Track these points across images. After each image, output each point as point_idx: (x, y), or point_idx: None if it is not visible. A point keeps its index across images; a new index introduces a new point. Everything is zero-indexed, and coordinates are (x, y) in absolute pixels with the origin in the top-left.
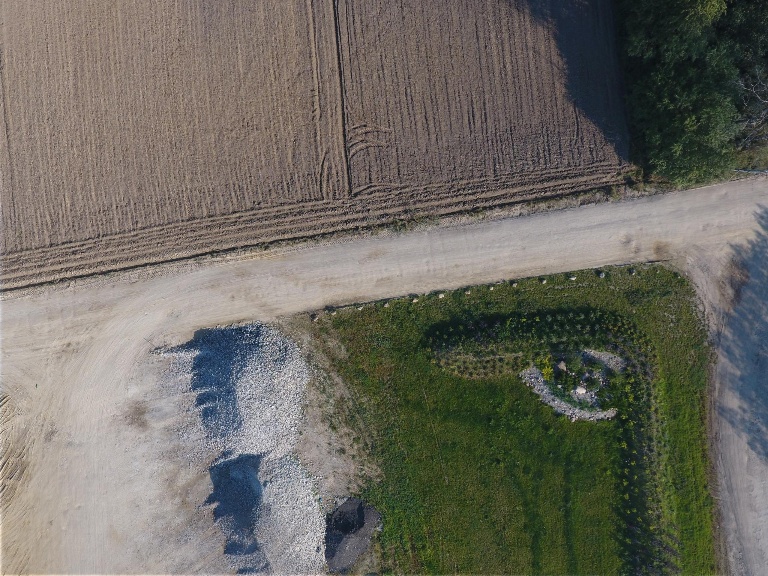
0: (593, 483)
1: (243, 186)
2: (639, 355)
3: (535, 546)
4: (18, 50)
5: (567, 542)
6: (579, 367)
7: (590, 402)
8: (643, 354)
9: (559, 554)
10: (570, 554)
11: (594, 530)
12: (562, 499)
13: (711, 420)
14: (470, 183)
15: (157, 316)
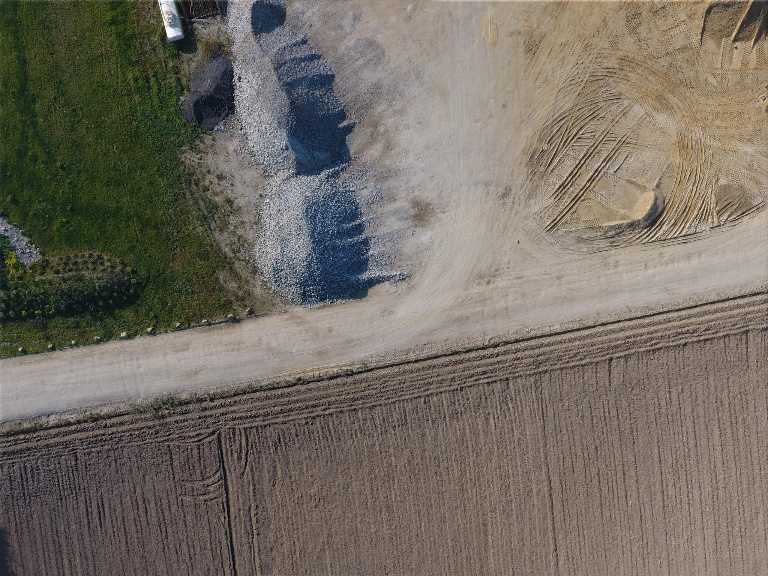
0: None
1: (323, 440)
2: None
3: (23, 81)
4: (540, 567)
5: None
6: None
7: None
8: None
9: None
10: None
11: None
12: None
13: None
14: (100, 446)
15: (404, 311)
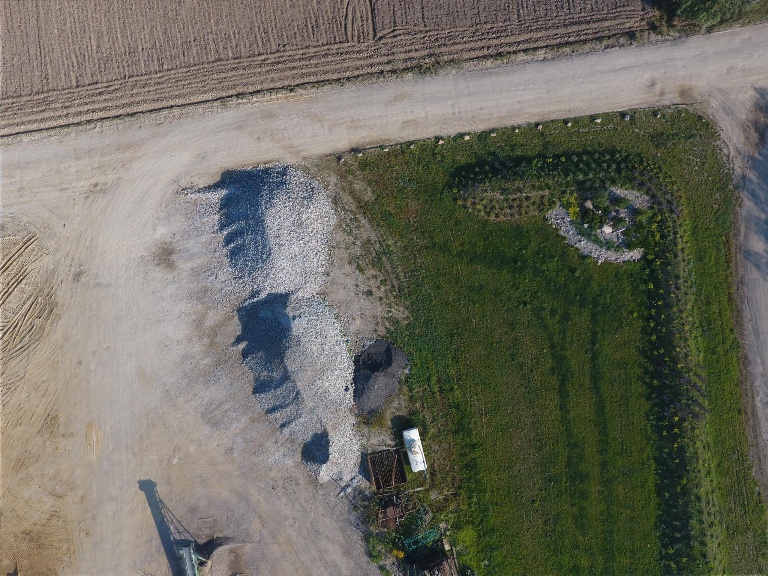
0: (620, 326)
1: (268, 29)
2: (665, 193)
3: (562, 389)
4: None
5: (594, 385)
6: (605, 205)
7: (616, 242)
8: (669, 192)
9: (586, 397)
10: (597, 397)
11: (621, 373)
12: (589, 342)
13: (737, 264)
14: (494, 27)
15: (184, 157)
